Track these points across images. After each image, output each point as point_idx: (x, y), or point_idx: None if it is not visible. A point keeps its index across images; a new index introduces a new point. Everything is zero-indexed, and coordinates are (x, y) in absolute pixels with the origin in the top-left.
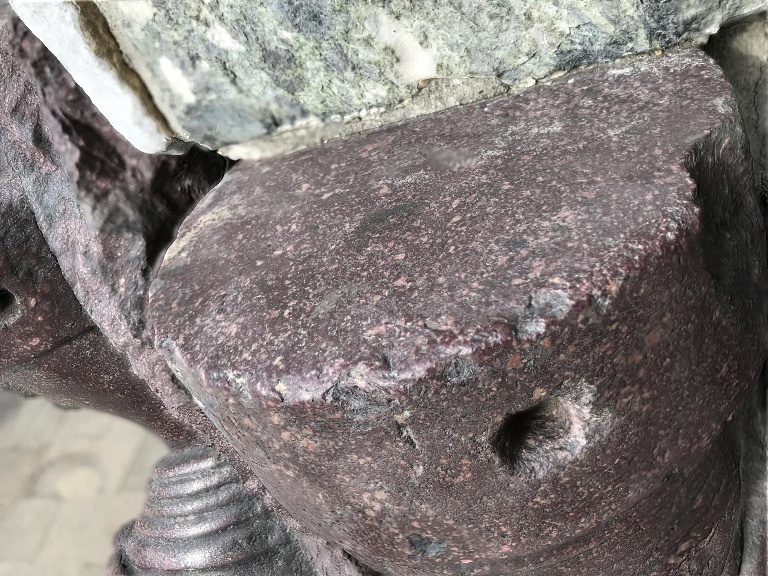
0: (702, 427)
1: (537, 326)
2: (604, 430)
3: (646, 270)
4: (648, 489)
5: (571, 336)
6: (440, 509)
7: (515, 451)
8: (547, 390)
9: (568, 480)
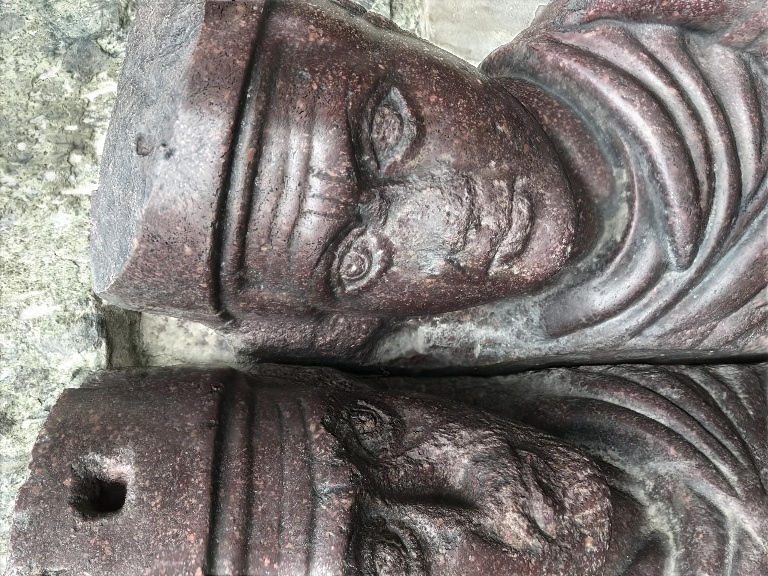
0: (195, 403)
1: (28, 474)
2: (131, 454)
3: (53, 417)
4: (206, 438)
5: (46, 458)
6: (133, 574)
7: (119, 510)
8: (69, 477)
9: (149, 481)
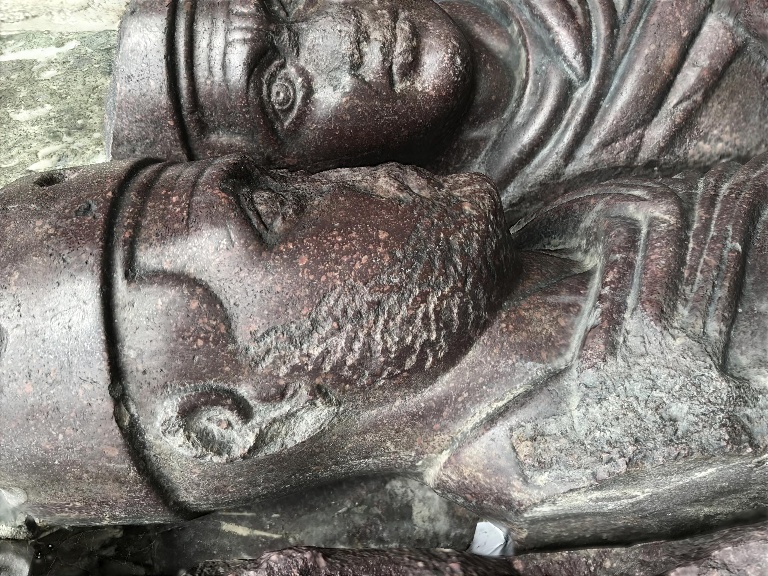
0: None
1: None
2: None
3: None
4: None
5: None
6: None
7: None
8: None
9: None
